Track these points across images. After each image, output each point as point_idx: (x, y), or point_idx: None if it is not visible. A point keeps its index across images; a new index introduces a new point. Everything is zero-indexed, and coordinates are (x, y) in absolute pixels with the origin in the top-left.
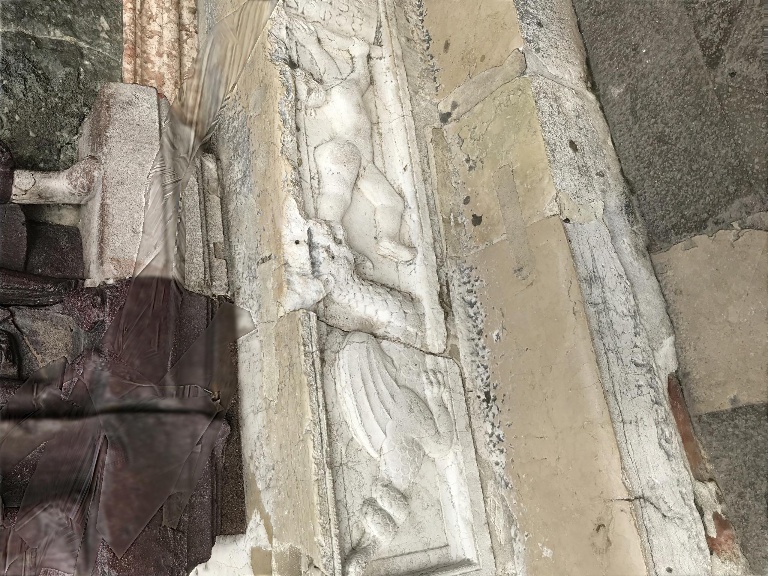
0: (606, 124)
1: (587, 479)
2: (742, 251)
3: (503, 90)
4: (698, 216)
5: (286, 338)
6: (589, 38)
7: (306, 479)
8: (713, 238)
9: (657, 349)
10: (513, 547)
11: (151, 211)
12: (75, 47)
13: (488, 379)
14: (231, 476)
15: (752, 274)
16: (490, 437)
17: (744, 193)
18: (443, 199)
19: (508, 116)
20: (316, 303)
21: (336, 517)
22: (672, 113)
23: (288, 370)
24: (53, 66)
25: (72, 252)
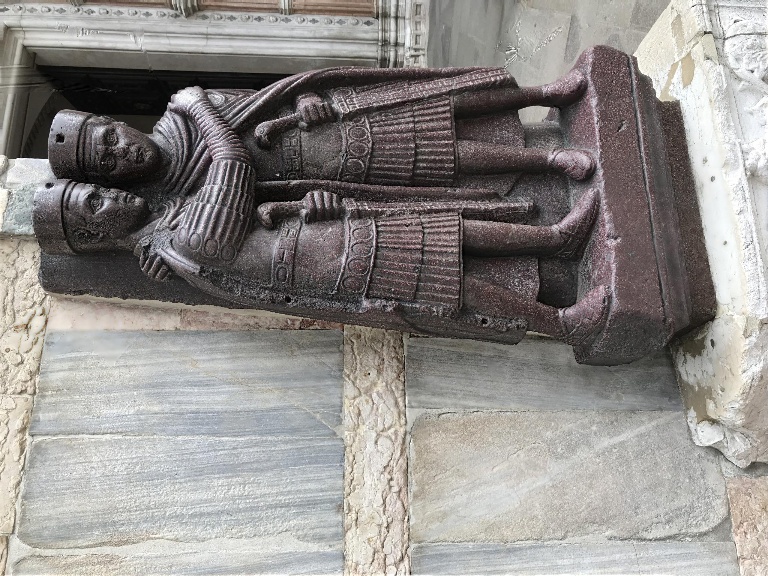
0: None
1: None
2: None
3: None
4: None
5: None
6: None
7: (649, 37)
8: None
9: None
10: None
11: None
12: None
13: None
14: None
15: None
16: None
17: None
18: None
19: None
20: None
21: None
22: None
23: None
24: None
25: None
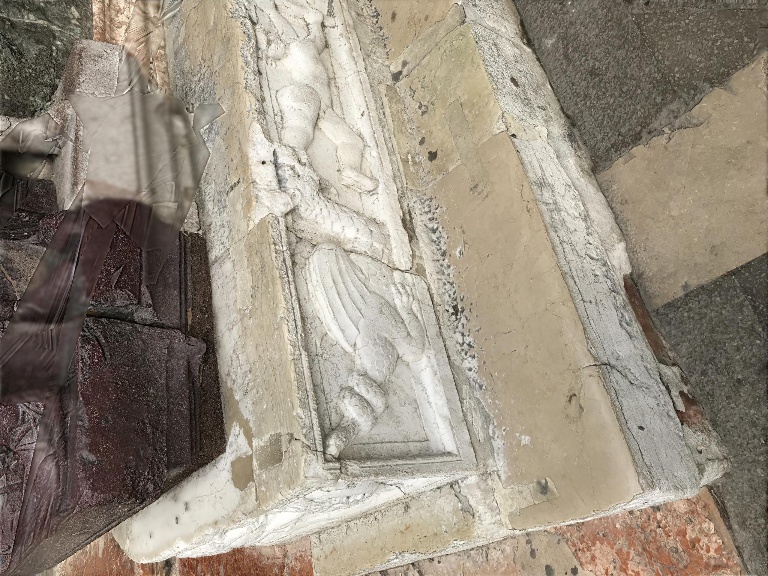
0: (543, 71)
1: (555, 356)
2: (675, 150)
3: (447, 39)
4: (633, 130)
5: (257, 244)
6: (521, 3)
7: (282, 362)
8: (648, 146)
9: (610, 250)
10: (492, 445)
11: (125, 64)
12: (48, 29)
13: (455, 294)
14: (209, 396)
15: (686, 168)
16: (461, 346)
17: (670, 100)
18: (400, 142)
19: (453, 59)
20: (284, 215)
21: (314, 394)
22: (599, 48)
23: (260, 272)
24: (27, 44)
25: (46, 196)
